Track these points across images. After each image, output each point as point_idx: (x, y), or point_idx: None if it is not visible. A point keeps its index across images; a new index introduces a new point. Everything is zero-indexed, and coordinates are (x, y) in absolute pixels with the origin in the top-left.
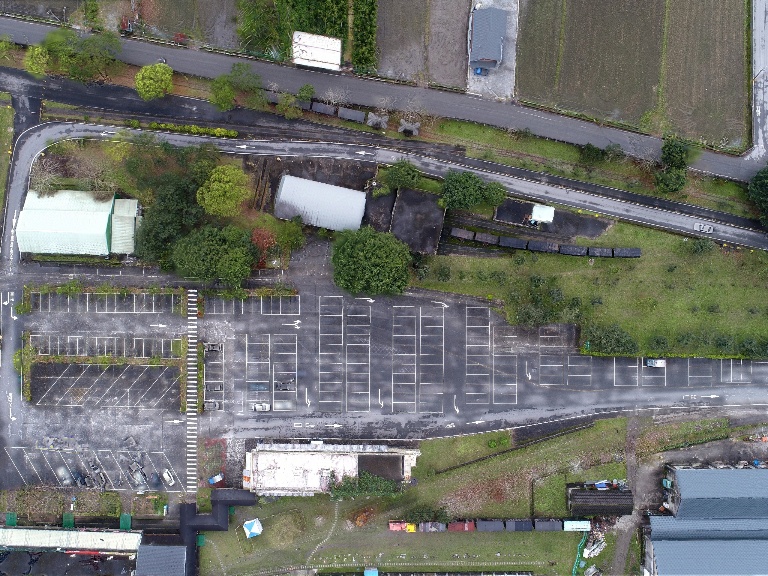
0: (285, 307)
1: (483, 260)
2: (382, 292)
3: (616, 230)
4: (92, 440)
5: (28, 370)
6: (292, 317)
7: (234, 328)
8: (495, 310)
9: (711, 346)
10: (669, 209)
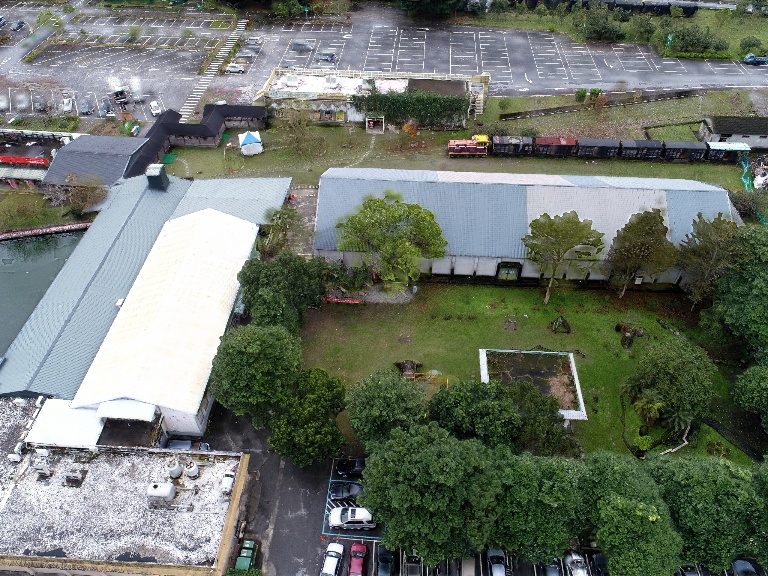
0: (337, 29)
1: None
2: (438, 26)
3: None
4: (78, 86)
5: (43, 47)
6: (343, 33)
7: (279, 36)
8: (559, 36)
9: None
10: (712, 2)
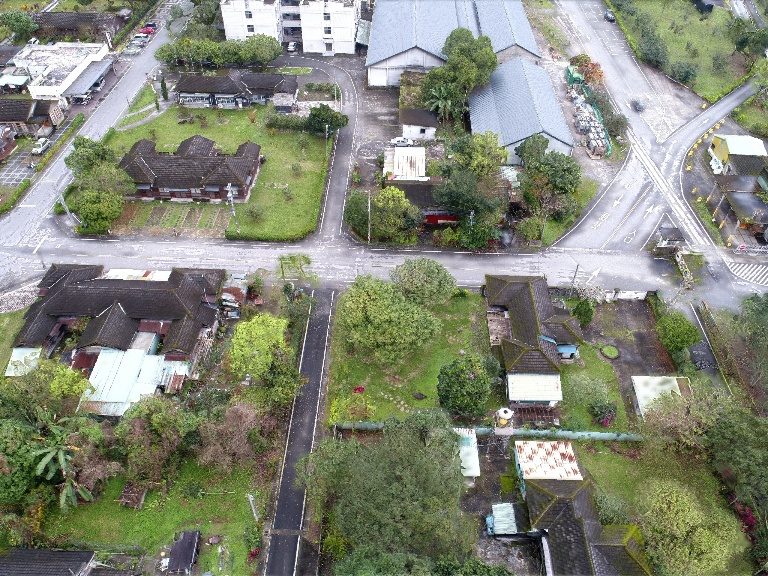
0: None
1: None
2: None
3: (720, 8)
4: None
5: None
6: None
7: None
8: None
9: (638, 40)
10: None
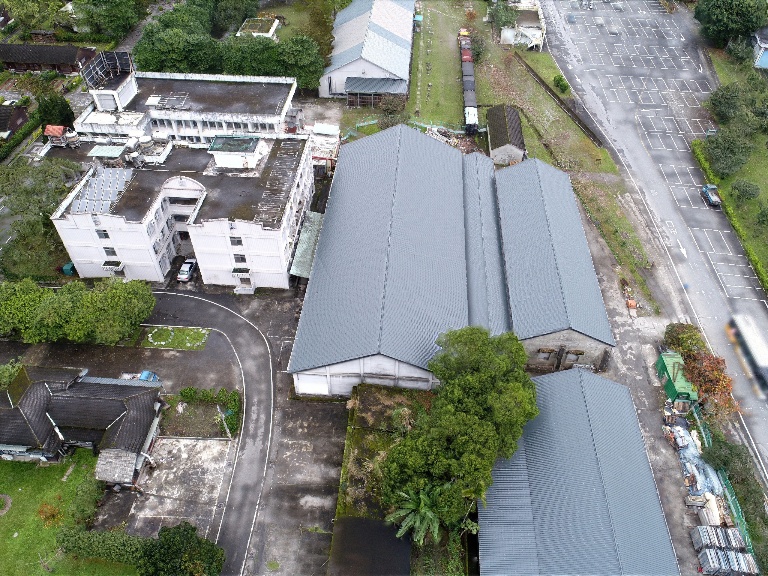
0: (655, 9)
1: (767, 91)
2: (695, 44)
3: None
4: None
5: None
6: None
7: None
8: None
9: (766, 256)
10: None
